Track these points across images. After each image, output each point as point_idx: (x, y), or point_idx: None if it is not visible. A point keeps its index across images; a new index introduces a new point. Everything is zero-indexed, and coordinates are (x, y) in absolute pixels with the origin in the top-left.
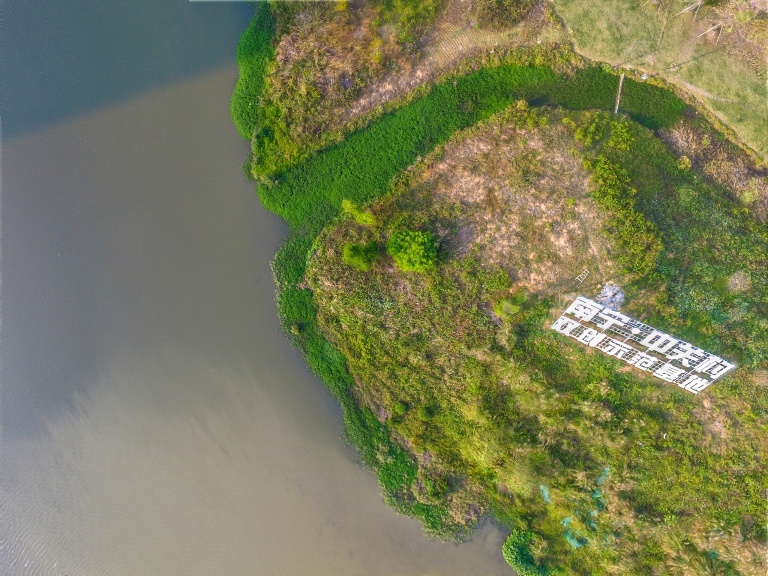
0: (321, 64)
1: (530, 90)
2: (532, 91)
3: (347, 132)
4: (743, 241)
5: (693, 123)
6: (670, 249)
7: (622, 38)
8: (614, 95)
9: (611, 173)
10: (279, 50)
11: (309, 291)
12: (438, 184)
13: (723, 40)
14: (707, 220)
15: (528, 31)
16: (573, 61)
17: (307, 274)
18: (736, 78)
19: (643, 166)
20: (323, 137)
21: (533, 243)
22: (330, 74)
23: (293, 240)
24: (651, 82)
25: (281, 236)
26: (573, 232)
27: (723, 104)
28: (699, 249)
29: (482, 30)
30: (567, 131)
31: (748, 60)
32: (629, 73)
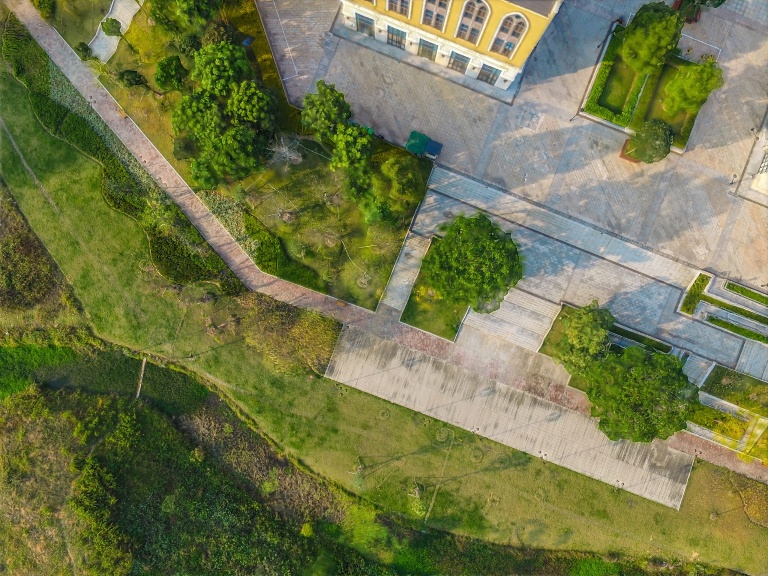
0: None
1: (50, 371)
2: (53, 372)
3: None
4: (241, 543)
5: (216, 410)
6: (148, 560)
7: (140, 325)
8: (136, 379)
9: (93, 479)
10: None
11: None
12: None
13: (243, 331)
14: (207, 520)
15: (42, 315)
16: (94, 344)
17: None
18: (254, 371)
19: (145, 463)
20: None
21: (10, 548)
22: None
23: None
24: (173, 368)
25: None
26: (50, 539)
27: (242, 395)
28: (185, 556)
29: None
30: (69, 424)
31: (267, 353)
32: (149, 359)
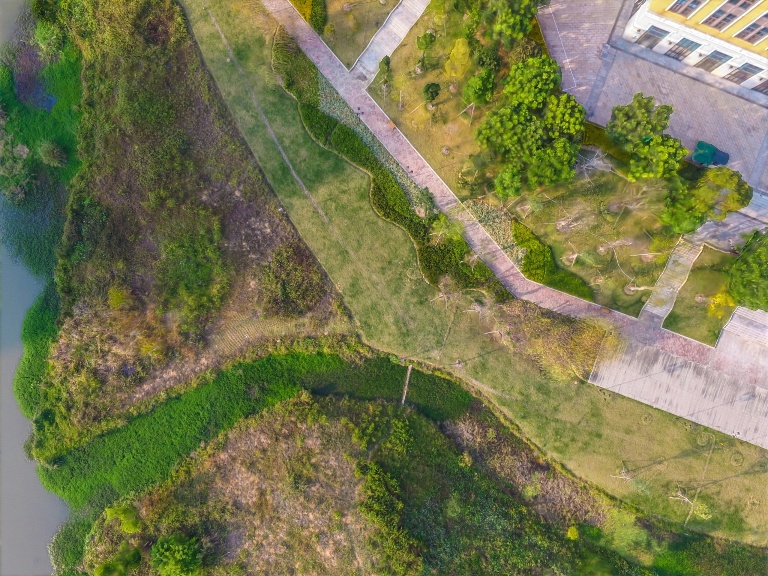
0: (103, 350)
1: (318, 377)
2: (320, 378)
3: (130, 416)
4: (515, 546)
5: (479, 416)
6: (435, 563)
7: (409, 333)
8: (401, 386)
9: (380, 485)
10: (62, 333)
11: (86, 575)
12: (215, 478)
13: None
14: (481, 523)
15: (314, 323)
16: (361, 351)
17: (84, 559)
18: (520, 377)
19: (420, 468)
20: (104, 423)
21: (299, 553)
22: (110, 363)
23: (72, 523)
24: (438, 374)
25: (60, 518)
26: (339, 544)
27: (507, 400)
28: (466, 560)
29: (269, 320)
30: (346, 430)
31: (533, 359)
32: (416, 366)
